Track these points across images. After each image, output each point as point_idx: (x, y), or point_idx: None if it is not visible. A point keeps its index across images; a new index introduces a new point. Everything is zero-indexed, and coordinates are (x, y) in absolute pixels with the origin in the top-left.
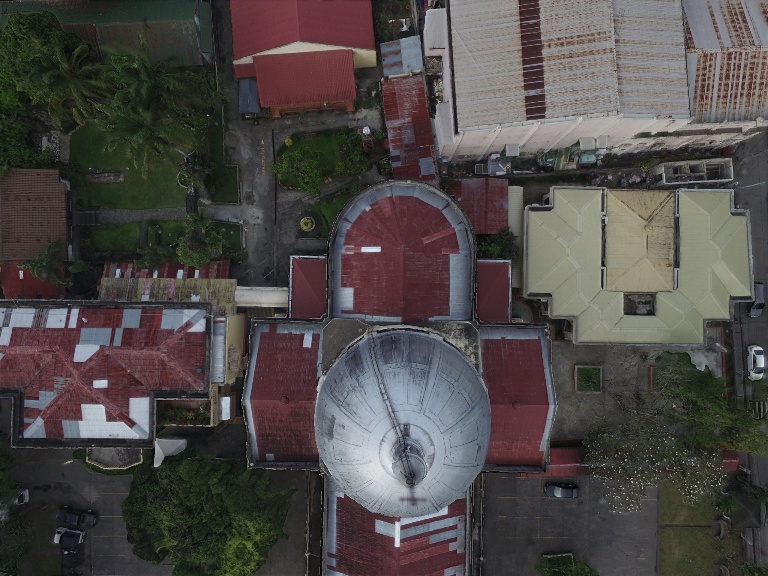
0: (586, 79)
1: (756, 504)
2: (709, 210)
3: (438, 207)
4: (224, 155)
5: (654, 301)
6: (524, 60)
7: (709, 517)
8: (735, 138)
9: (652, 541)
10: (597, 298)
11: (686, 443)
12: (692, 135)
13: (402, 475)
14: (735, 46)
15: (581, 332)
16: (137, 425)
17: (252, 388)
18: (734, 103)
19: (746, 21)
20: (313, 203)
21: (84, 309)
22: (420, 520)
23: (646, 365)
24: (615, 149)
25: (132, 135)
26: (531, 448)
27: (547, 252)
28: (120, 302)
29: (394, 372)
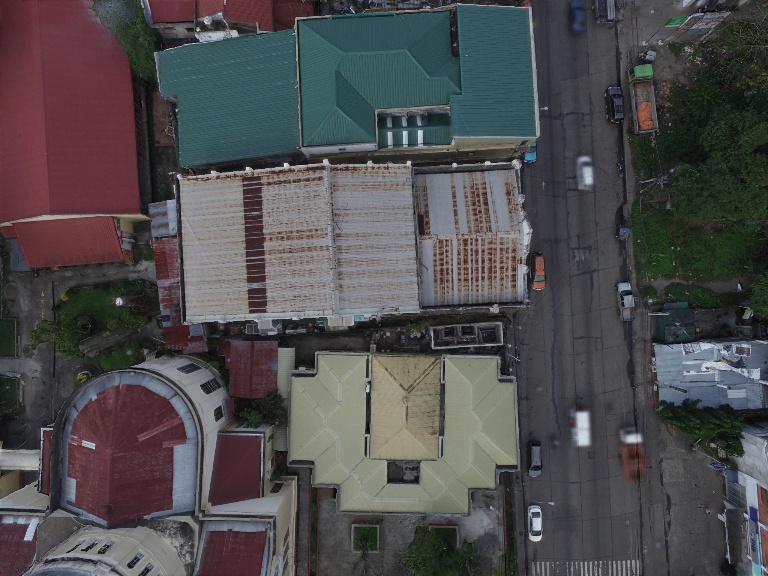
0: (304, 275)
1: None
2: (472, 379)
3: (165, 396)
4: (2, 309)
5: None
6: (247, 252)
7: None
8: None
9: None
10: (359, 467)
11: None
12: None
13: None
14: (471, 232)
15: (343, 501)
16: None
17: None
18: (476, 286)
19: (487, 203)
20: (92, 356)
21: None
22: None
23: (425, 523)
24: None
25: None
26: None
27: (307, 421)
28: None
29: None
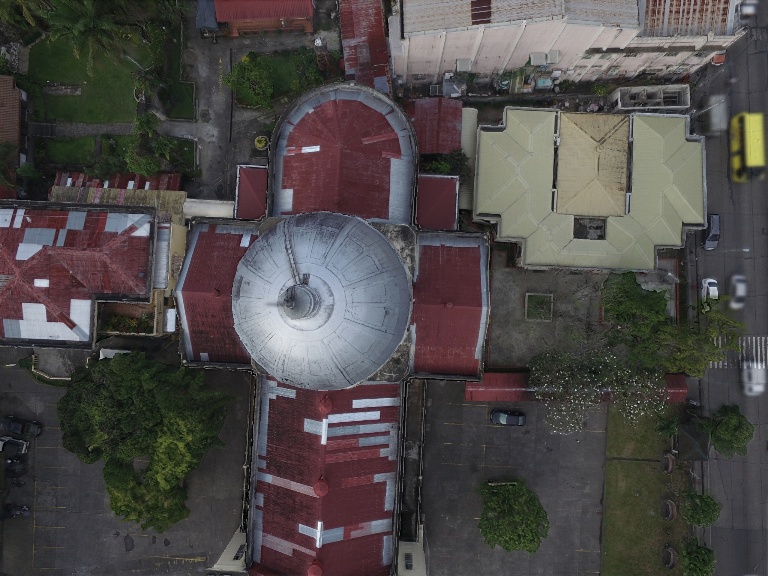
0: None
1: (703, 436)
2: (663, 134)
3: (381, 112)
4: (181, 72)
5: (605, 226)
6: None
7: (658, 452)
8: (692, 63)
9: (599, 474)
10: (547, 220)
11: (628, 363)
12: (645, 54)
13: (285, 302)
14: None
15: (529, 254)
16: (77, 327)
17: (185, 281)
18: (686, 19)
19: None
20: (268, 123)
21: (30, 210)
22: (350, 421)
23: (598, 295)
24: (570, 72)
25: (74, 24)
26: (466, 356)
27: (497, 172)
28: (65, 203)
29: (303, 232)
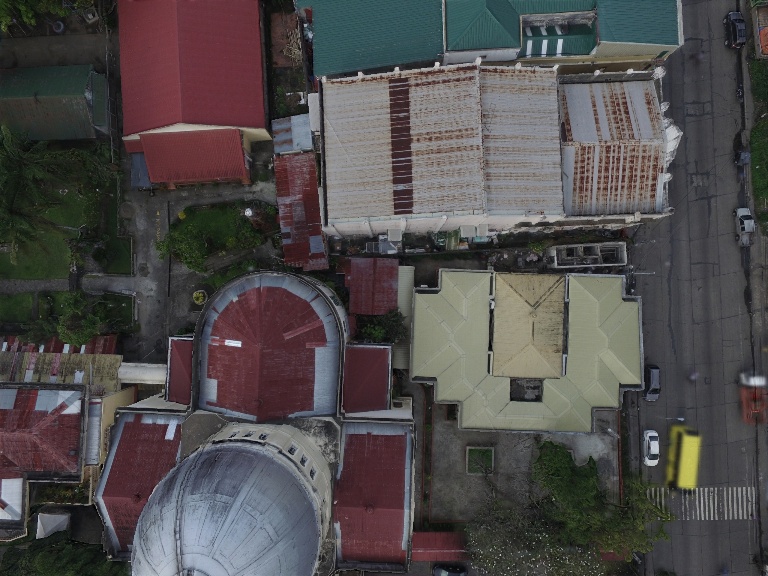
0: (453, 175)
1: None
2: (598, 297)
3: (306, 299)
4: (118, 226)
5: (543, 387)
6: (393, 153)
7: None
8: None
9: None
10: (482, 384)
11: (561, 540)
12: None
13: None
14: (614, 139)
15: (466, 418)
16: (9, 506)
17: (106, 484)
18: (615, 195)
19: (628, 112)
20: (207, 276)
21: None
22: None
23: None
24: (505, 232)
25: None
26: (393, 547)
27: (432, 336)
28: None
29: (195, 506)
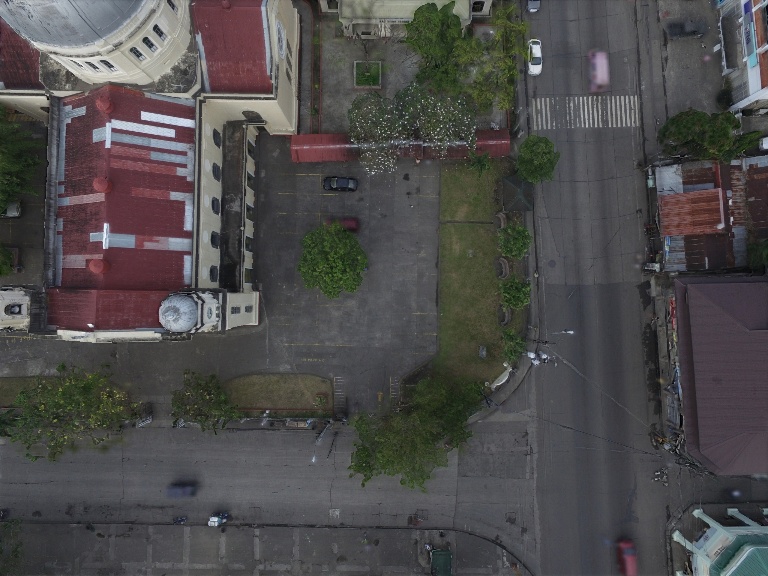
0: None
1: (526, 184)
2: None
3: None
4: None
5: None
6: None
7: (490, 213)
8: None
9: (433, 238)
10: None
11: (432, 91)
12: None
13: None
14: None
15: (345, 7)
16: None
17: None
18: None
19: None
20: None
21: None
22: (138, 132)
23: None
24: None
25: None
26: (258, 72)
27: None
28: None
29: None
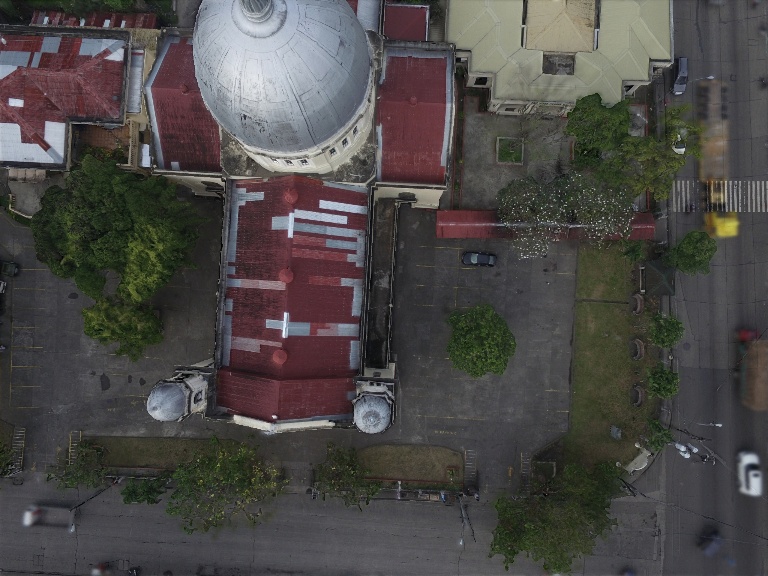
0: None
1: (670, 270)
2: None
3: None
4: None
5: (574, 63)
6: None
7: (627, 293)
8: None
9: (569, 315)
10: (516, 55)
11: (593, 181)
12: None
13: None
14: None
15: (499, 88)
16: (52, 149)
17: (154, 80)
18: None
19: None
20: None
21: (5, 35)
22: (316, 220)
23: (569, 140)
24: None
25: None
26: (432, 162)
27: (467, 6)
28: (40, 28)
29: None
